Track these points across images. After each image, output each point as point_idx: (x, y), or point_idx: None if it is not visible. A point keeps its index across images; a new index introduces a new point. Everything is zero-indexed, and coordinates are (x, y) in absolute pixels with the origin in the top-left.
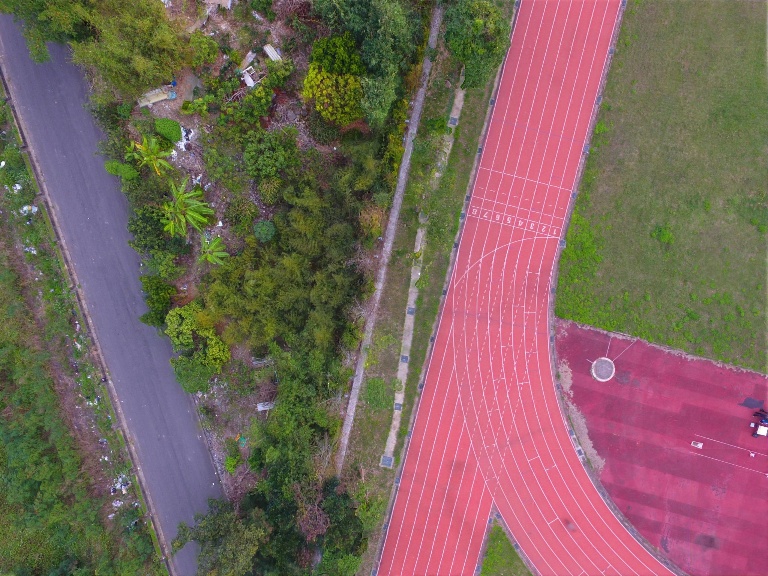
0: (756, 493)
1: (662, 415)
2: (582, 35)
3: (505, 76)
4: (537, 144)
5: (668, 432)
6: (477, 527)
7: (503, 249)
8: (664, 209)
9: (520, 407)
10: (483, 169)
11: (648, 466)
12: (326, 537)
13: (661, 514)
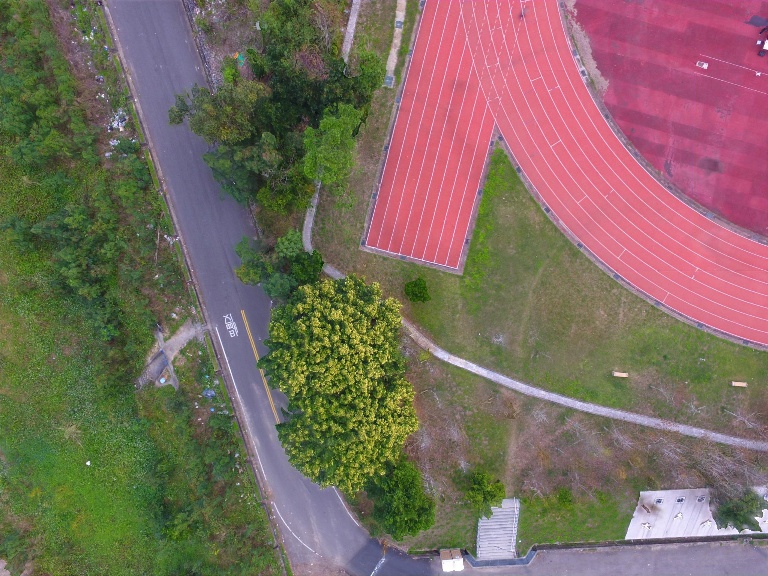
0: (761, 115)
1: (667, 34)
2: None
3: None
4: None
5: (673, 52)
6: (479, 149)
7: None
8: None
9: (523, 25)
10: None
11: (652, 87)
12: (326, 87)
13: (665, 137)
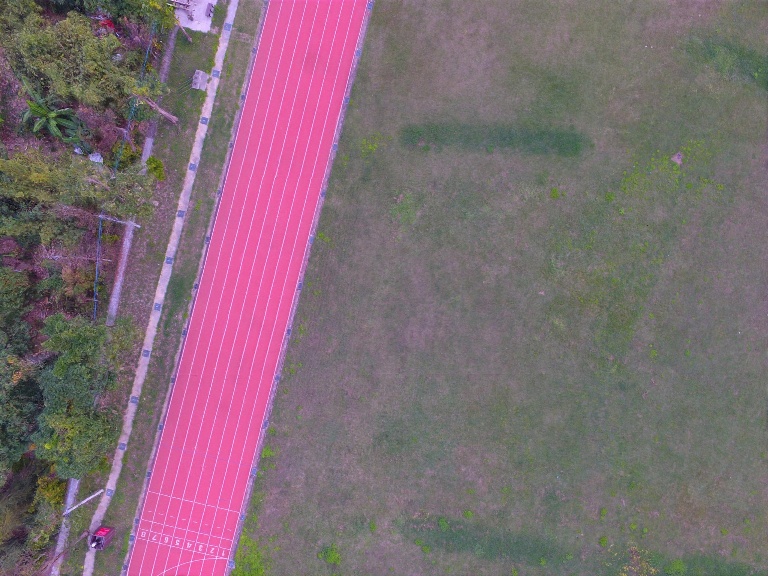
0: None
1: None
2: (248, 363)
3: (173, 402)
4: (205, 468)
5: None
6: None
7: (172, 571)
8: (330, 530)
9: None
10: (151, 493)
11: None
12: None
13: None
